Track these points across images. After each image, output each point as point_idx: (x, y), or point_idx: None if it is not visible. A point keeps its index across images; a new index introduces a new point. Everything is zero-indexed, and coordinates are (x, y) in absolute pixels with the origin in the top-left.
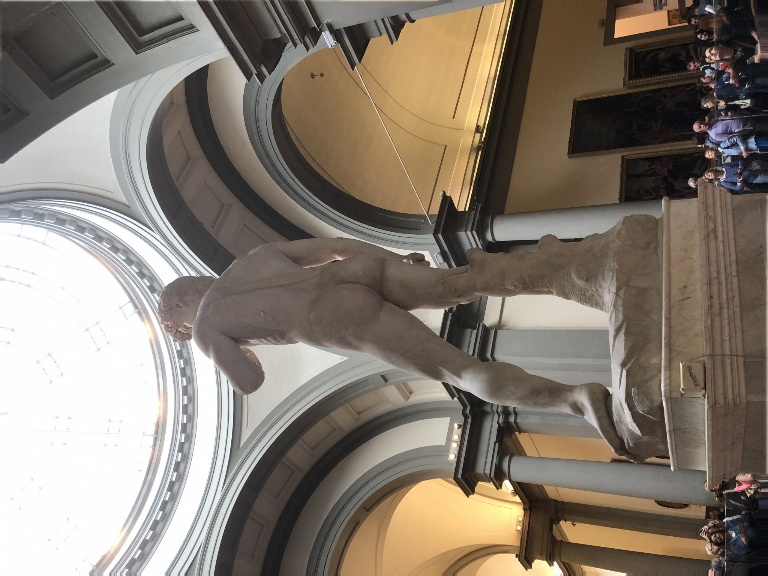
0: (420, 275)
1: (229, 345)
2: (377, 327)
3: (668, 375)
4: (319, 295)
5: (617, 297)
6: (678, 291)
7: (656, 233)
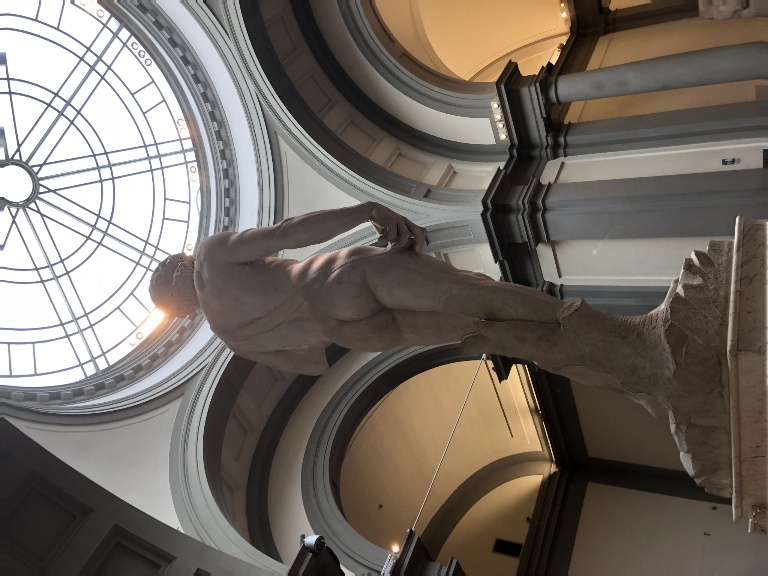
0: (421, 304)
1: (278, 360)
2: (408, 344)
3: (740, 511)
4: (328, 332)
5: (678, 430)
6: (750, 450)
7: (720, 378)
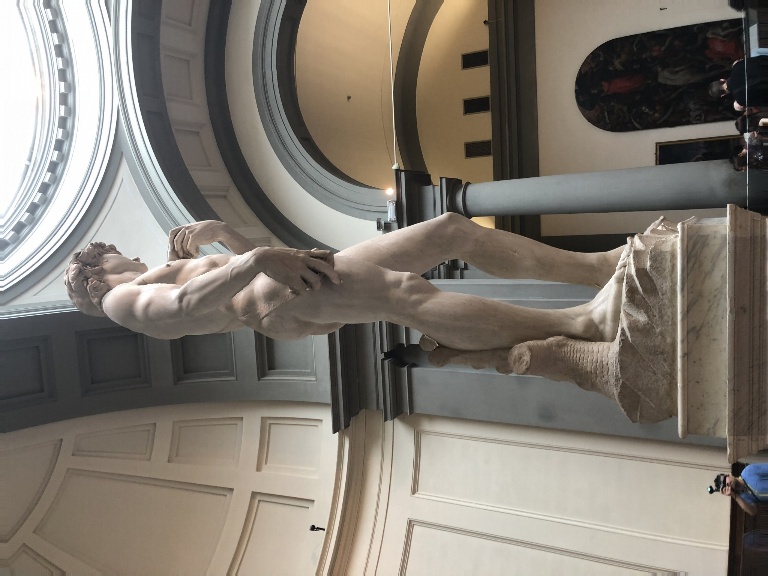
0: None
1: None
2: None
3: None
4: None
5: None
6: None
7: None
